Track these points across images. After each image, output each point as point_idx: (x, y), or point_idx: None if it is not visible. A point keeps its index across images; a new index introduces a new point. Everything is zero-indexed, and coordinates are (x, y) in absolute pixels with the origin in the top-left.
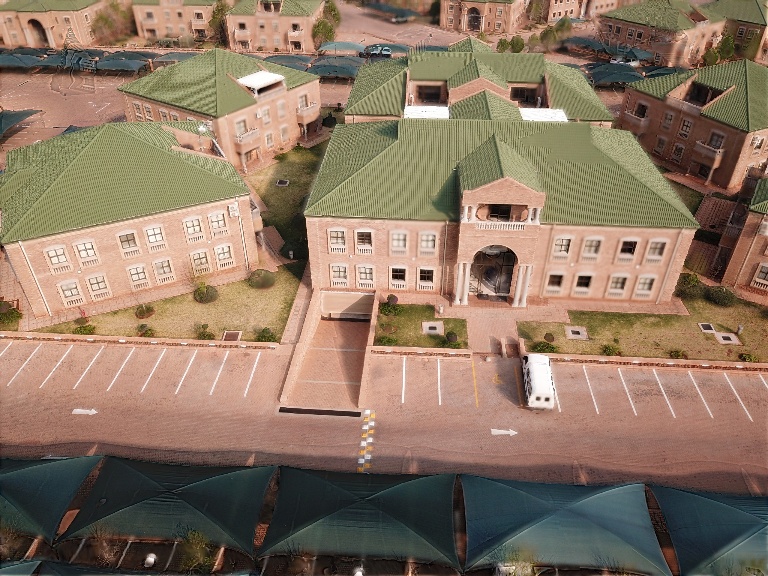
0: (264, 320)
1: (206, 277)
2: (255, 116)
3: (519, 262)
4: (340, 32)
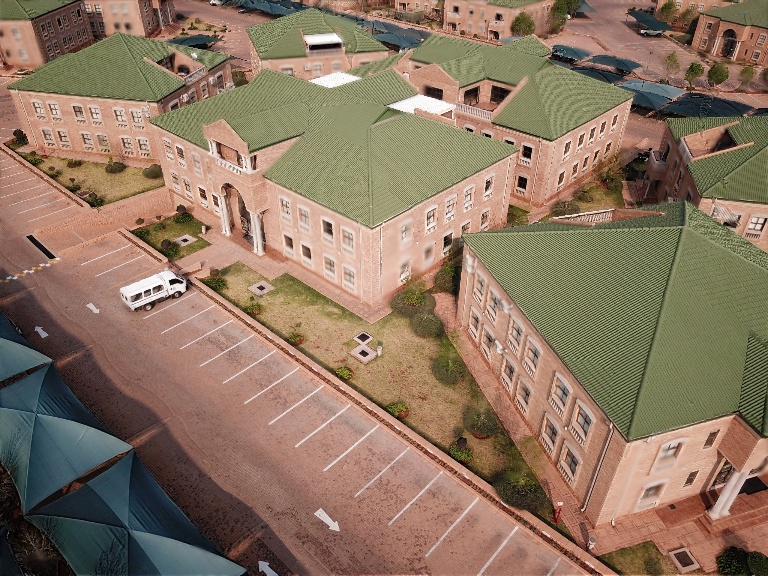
0: (115, 193)
1: (133, 159)
2: (304, 68)
3: (246, 207)
4: (571, 33)
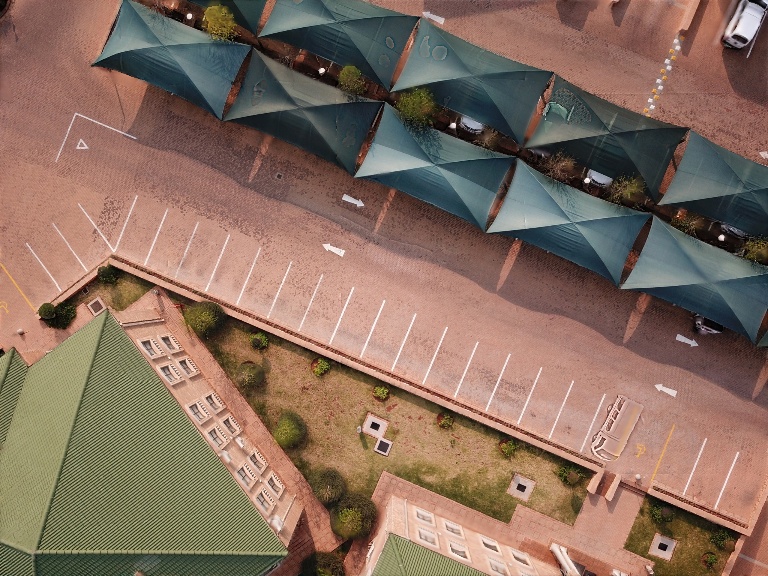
0: None
1: None
2: None
3: None
4: None
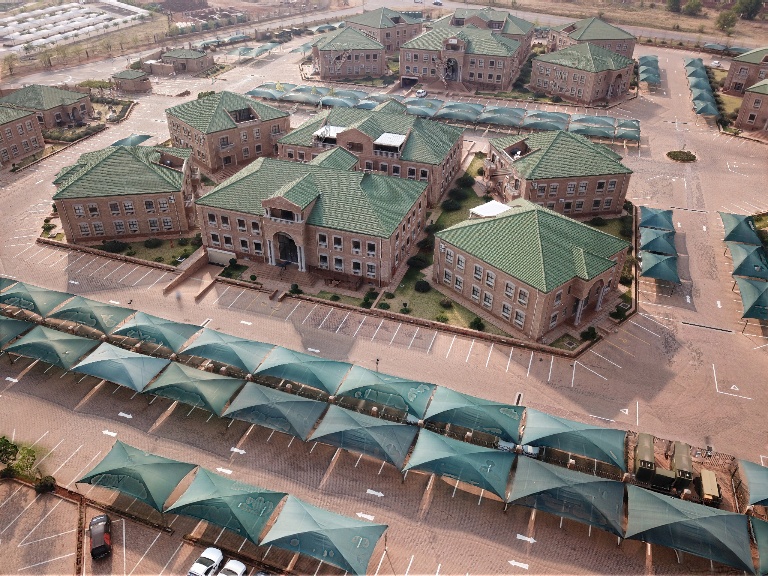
0: None
1: None
2: None
3: None
4: None
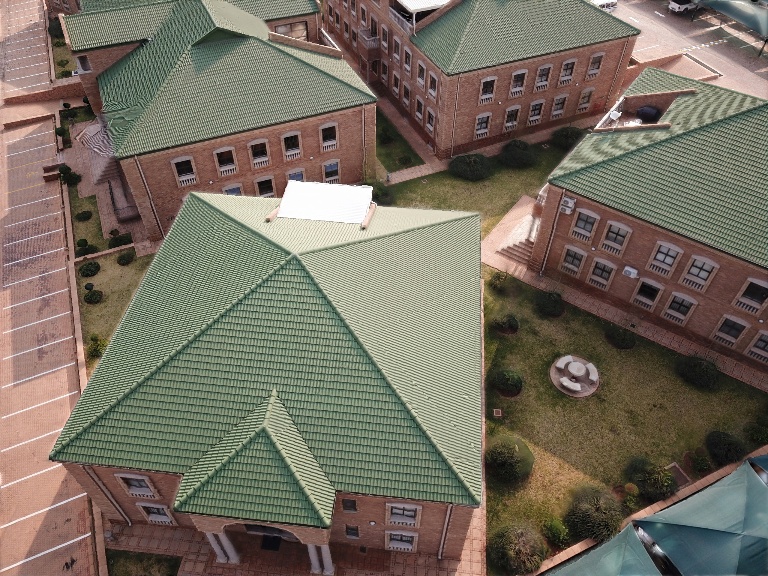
0: None
1: None
2: None
3: None
4: None
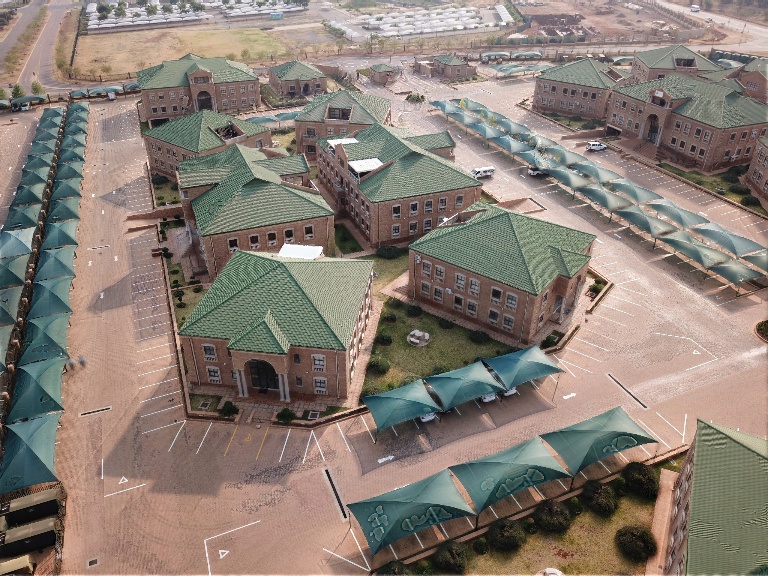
0: None
1: None
2: None
3: None
4: None
